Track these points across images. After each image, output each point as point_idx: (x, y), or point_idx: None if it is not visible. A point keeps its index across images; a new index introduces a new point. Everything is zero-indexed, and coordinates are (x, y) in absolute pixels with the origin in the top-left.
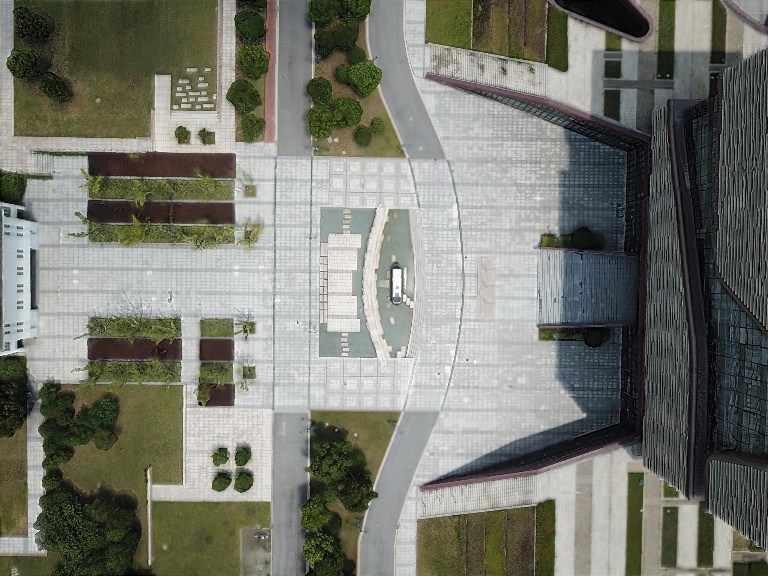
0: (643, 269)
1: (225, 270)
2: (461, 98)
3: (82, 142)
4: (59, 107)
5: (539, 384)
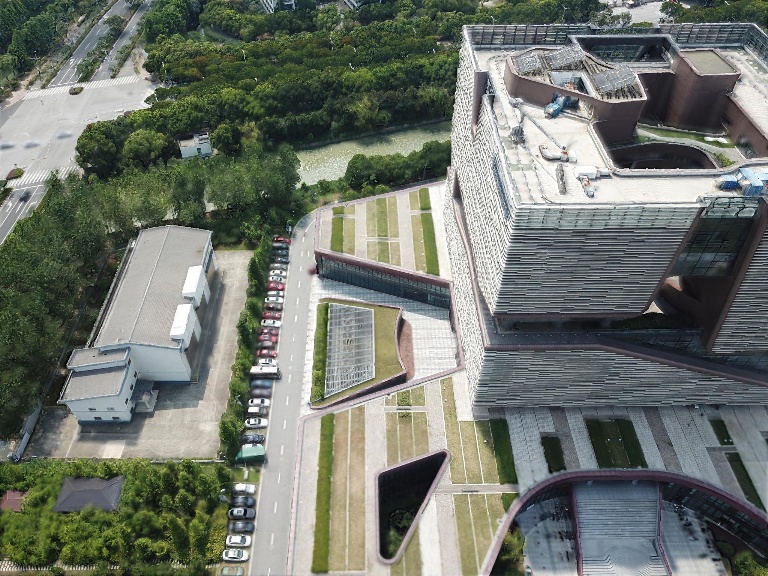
0: None
1: None
2: None
3: None
4: None
5: None
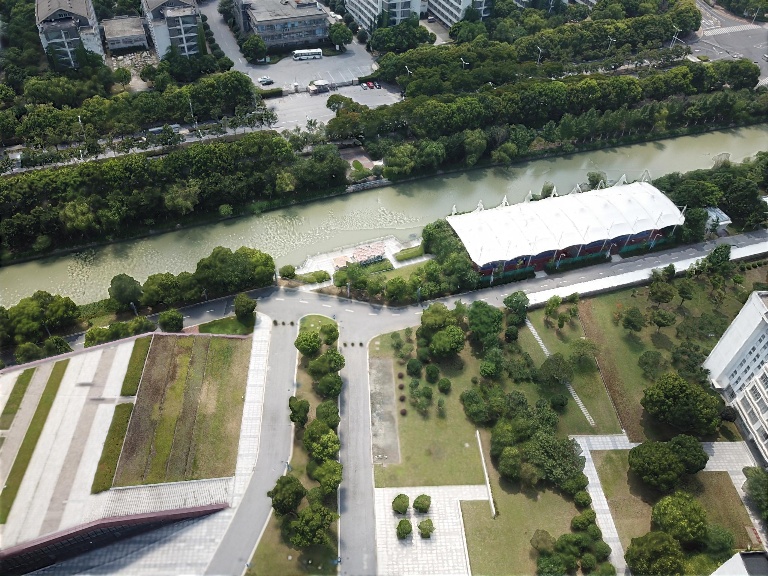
0: None
1: None
2: None
3: None
4: None
5: None
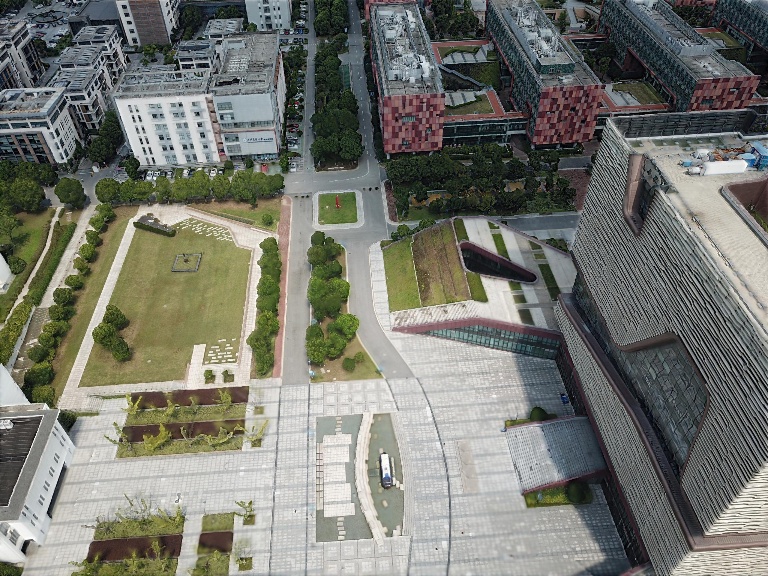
0: (591, 416)
1: (231, 471)
2: (420, 340)
3: (130, 387)
4: (118, 367)
5: (540, 551)
